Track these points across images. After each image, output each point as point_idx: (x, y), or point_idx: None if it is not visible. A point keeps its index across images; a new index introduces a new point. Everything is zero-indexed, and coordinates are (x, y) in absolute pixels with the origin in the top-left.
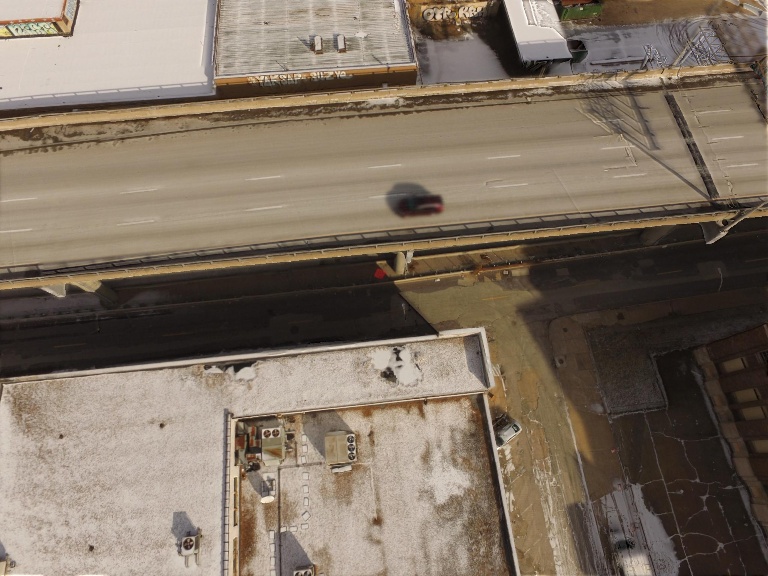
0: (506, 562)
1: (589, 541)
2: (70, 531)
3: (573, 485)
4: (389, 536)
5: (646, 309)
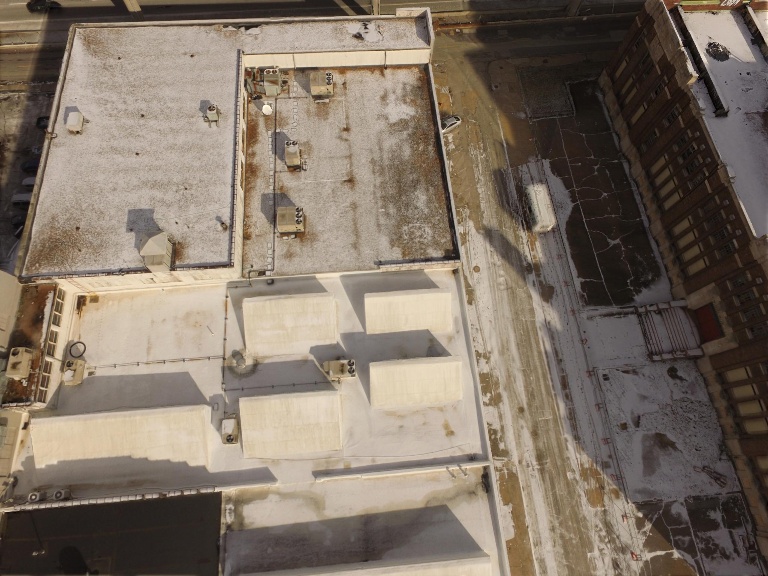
0: (437, 154)
1: (507, 190)
2: (127, 106)
3: (498, 158)
4: (354, 137)
5: (566, 57)
